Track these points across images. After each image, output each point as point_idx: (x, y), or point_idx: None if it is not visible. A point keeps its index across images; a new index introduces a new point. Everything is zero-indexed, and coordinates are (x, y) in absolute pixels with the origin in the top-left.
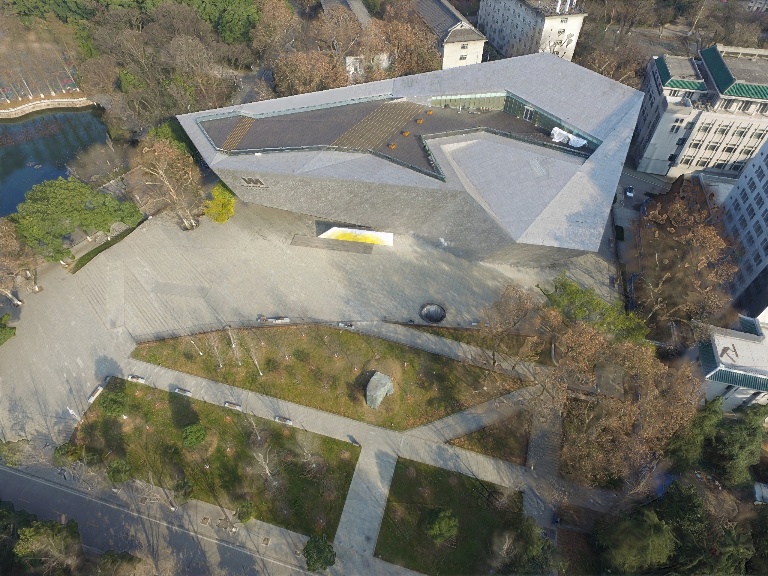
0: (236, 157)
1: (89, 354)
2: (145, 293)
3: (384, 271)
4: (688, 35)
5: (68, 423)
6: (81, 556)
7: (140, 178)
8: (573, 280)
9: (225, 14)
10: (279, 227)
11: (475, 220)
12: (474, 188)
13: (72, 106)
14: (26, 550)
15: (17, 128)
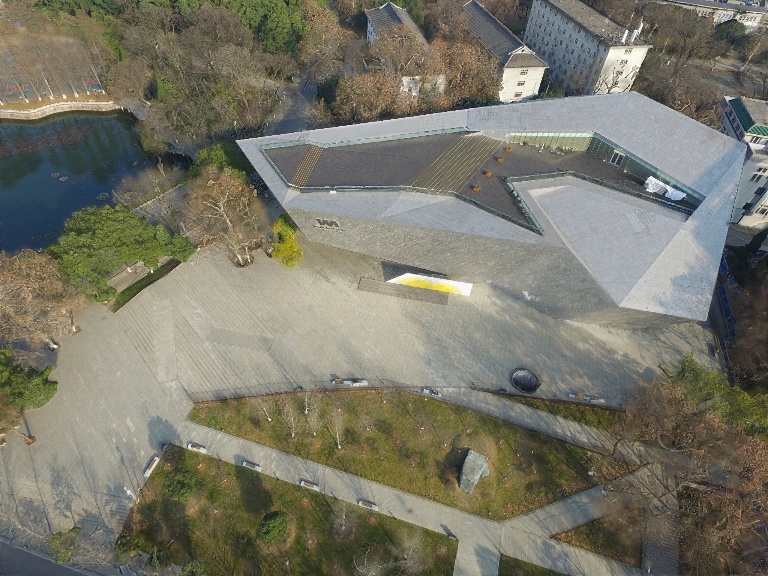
0: (309, 194)
1: (140, 414)
2: (199, 341)
3: (464, 326)
4: (741, 70)
5: (122, 503)
6: None
7: (180, 199)
8: (669, 346)
9: (269, 21)
10: (342, 267)
11: (572, 278)
12: (567, 241)
13: (97, 110)
14: None
15: (34, 130)
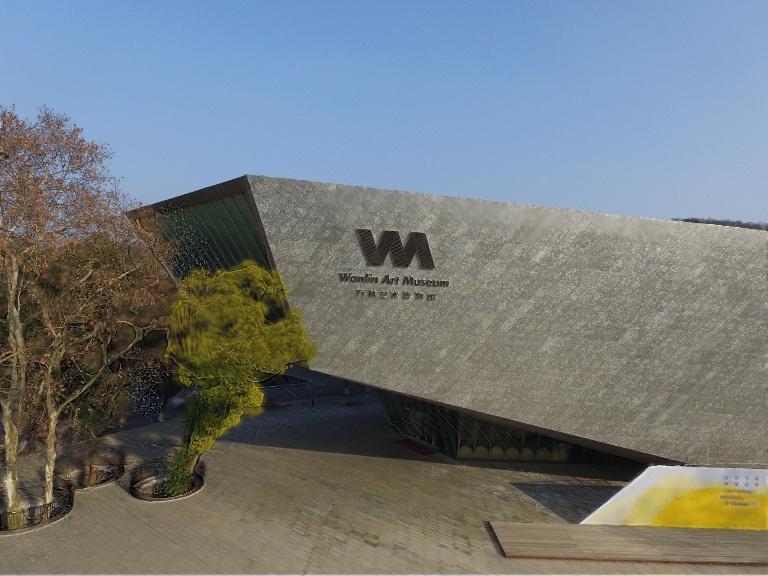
0: None
1: None
2: None
3: None
4: None
5: None
6: None
7: None
8: None
9: None
10: (405, 503)
11: None
12: None
13: None
14: None
15: None
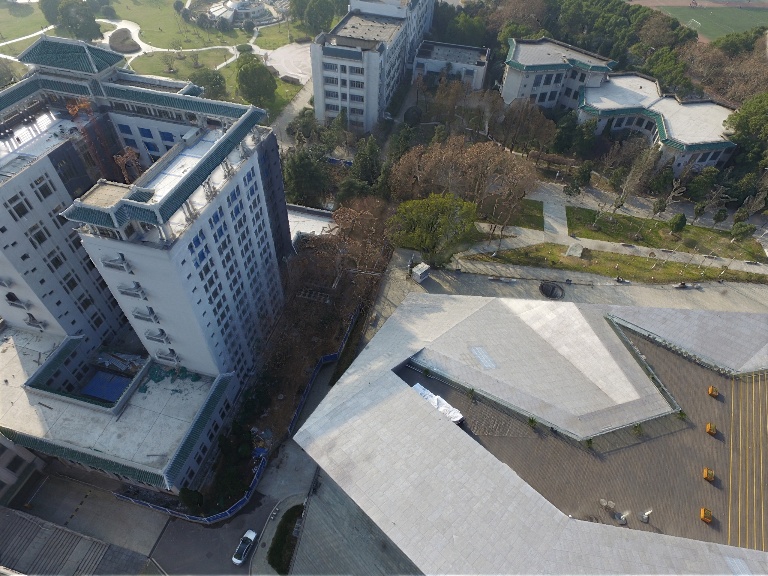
0: None
1: None
2: None
3: None
4: None
5: (764, 240)
6: (683, 179)
7: None
8: None
9: None
10: None
11: None
12: (561, 347)
13: None
14: (708, 167)
15: None
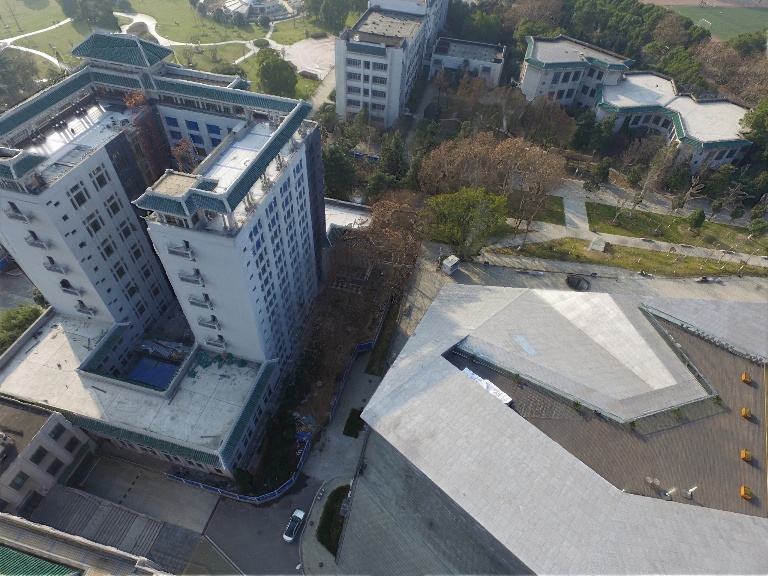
0: None
1: None
2: None
3: None
4: None
5: None
6: None
7: None
8: None
9: None
10: None
11: None
12: (596, 336)
13: None
14: (725, 165)
15: None
